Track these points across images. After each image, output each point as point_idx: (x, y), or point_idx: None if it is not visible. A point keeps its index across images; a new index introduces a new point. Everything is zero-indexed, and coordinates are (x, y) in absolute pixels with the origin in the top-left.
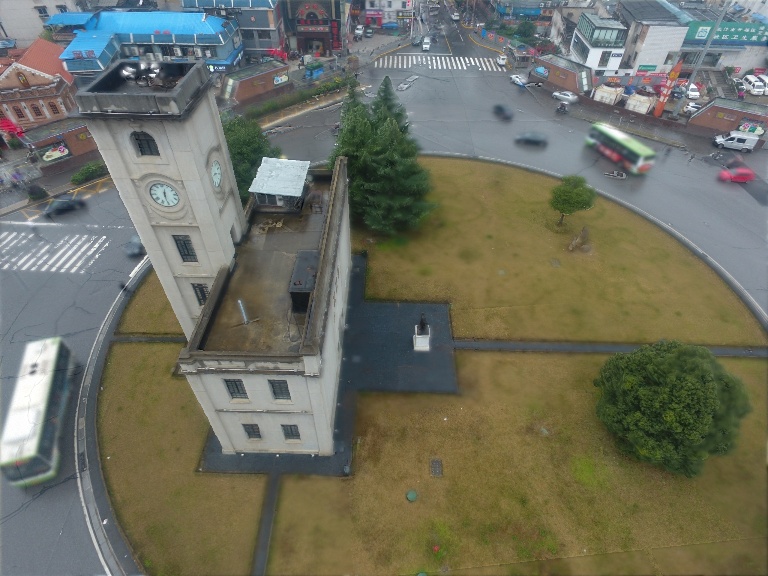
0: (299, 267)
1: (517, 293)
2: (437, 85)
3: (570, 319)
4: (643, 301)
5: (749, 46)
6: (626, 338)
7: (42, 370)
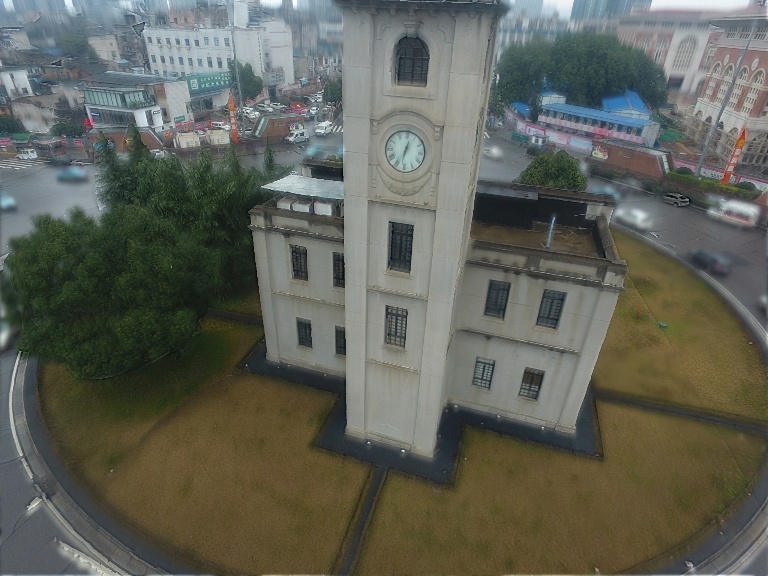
0: (501, 193)
1: None
2: (2, 193)
3: None
4: None
5: (222, 89)
6: None
7: None
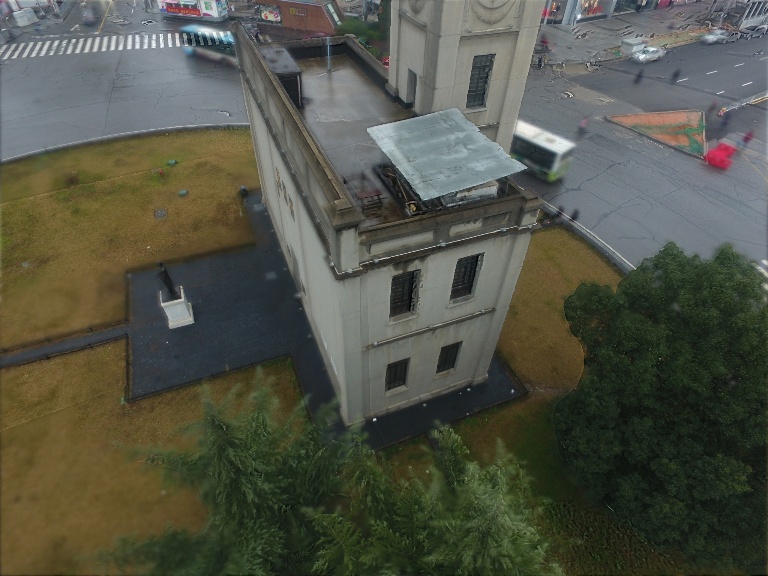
0: (288, 60)
1: None
2: None
3: None
4: None
5: None
6: None
7: (575, 189)
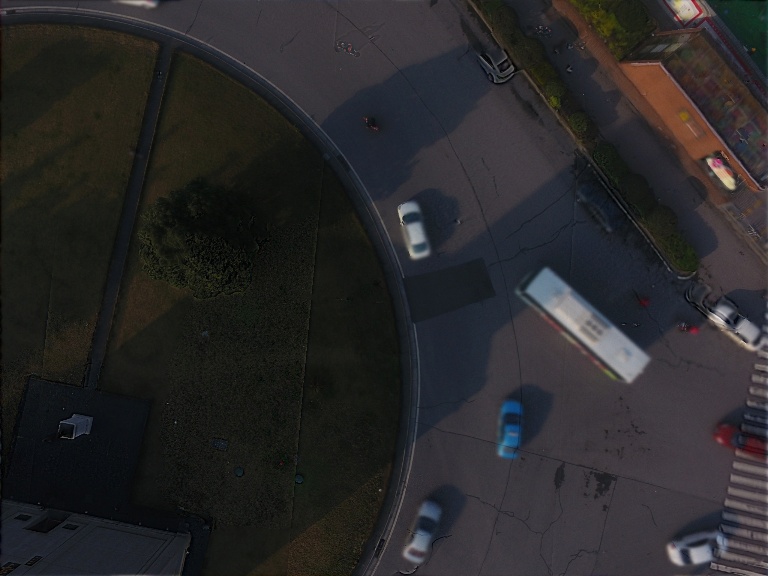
0: None
1: (29, 289)
2: None
3: (81, 244)
4: (71, 145)
5: None
6: (119, 196)
7: None
